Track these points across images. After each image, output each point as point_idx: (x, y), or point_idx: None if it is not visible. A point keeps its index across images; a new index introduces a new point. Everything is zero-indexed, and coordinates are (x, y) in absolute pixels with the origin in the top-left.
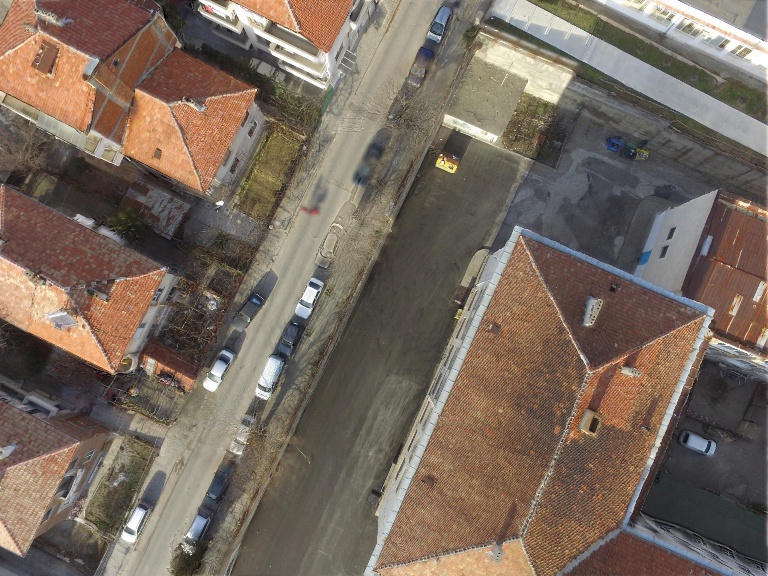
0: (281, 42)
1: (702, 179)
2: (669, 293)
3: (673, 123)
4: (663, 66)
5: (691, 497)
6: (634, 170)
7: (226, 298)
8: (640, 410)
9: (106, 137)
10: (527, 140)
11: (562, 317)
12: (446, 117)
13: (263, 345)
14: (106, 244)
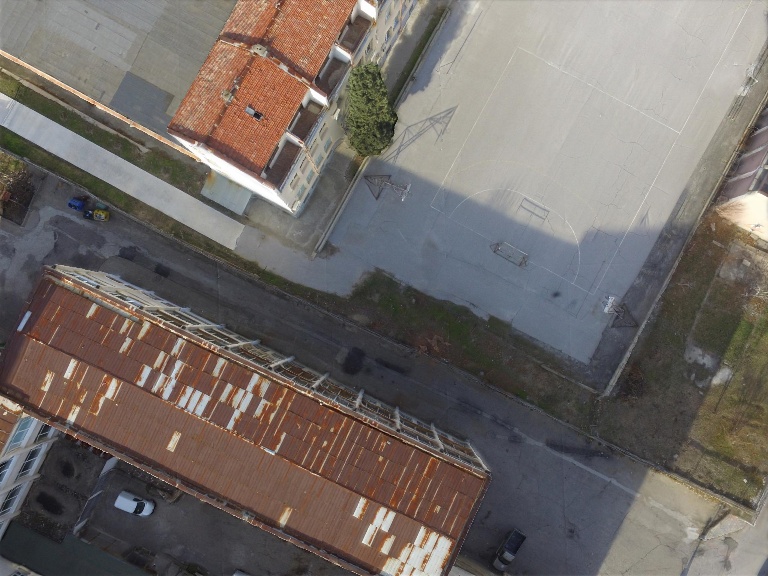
0: None
1: (165, 242)
2: None
3: (92, 190)
4: (86, 133)
5: (91, 559)
6: (101, 230)
7: None
8: None
9: None
10: None
11: None
12: None
13: None
14: None
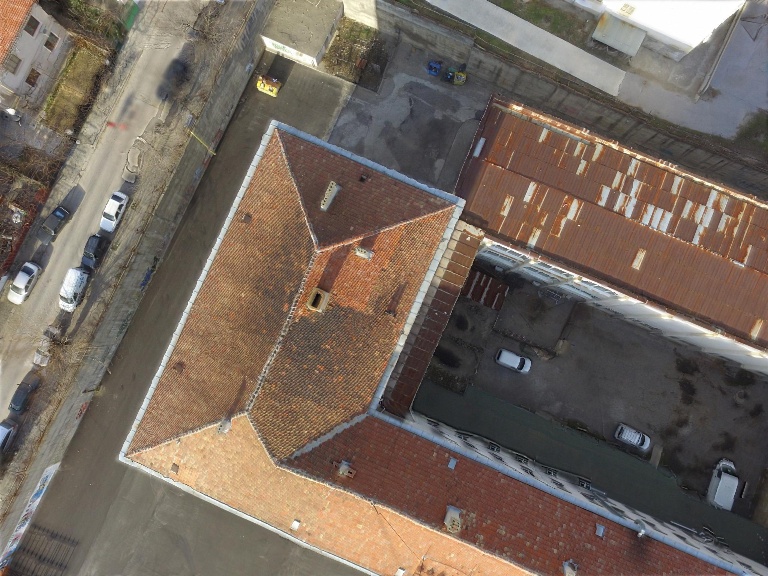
0: None
1: None
2: (421, 185)
3: (477, 41)
4: None
5: (495, 409)
6: (455, 94)
7: (27, 209)
8: (384, 296)
9: None
10: (349, 64)
11: (301, 201)
12: (265, 40)
13: (70, 259)
14: None
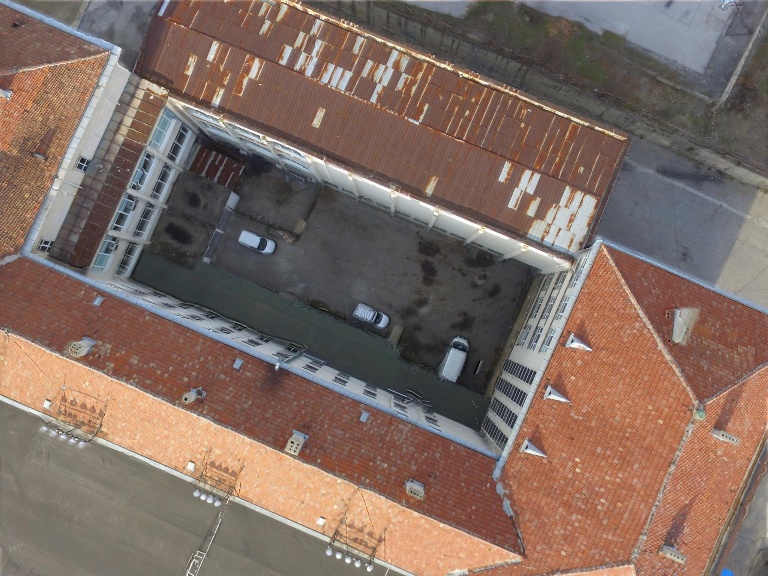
0: None
1: None
2: (77, 32)
3: None
4: None
5: (224, 283)
6: None
7: None
8: (32, 138)
9: None
10: None
11: None
12: None
13: None
14: None
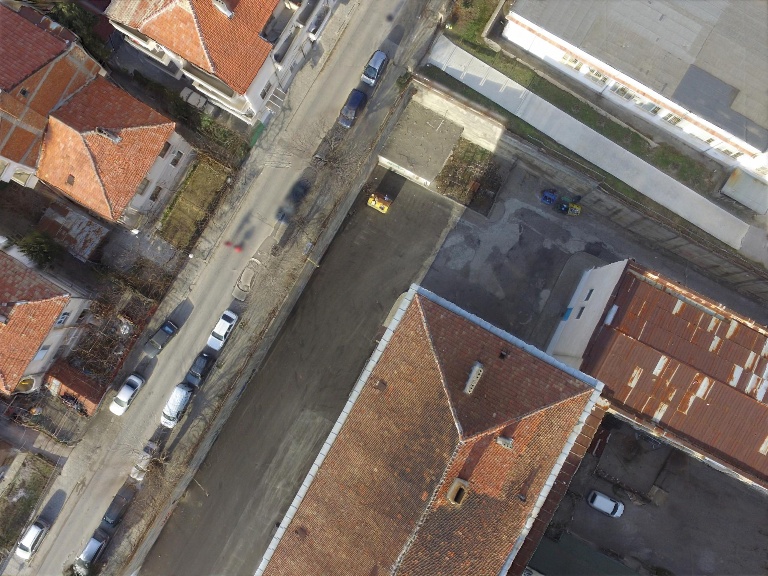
0: (198, 80)
1: (633, 239)
2: (560, 364)
3: (602, 184)
4: (596, 126)
5: (589, 560)
6: (566, 224)
7: (137, 324)
8: (517, 480)
9: (16, 161)
10: (461, 186)
11: (444, 382)
12: (380, 158)
13: (173, 373)
14: (12, 265)
